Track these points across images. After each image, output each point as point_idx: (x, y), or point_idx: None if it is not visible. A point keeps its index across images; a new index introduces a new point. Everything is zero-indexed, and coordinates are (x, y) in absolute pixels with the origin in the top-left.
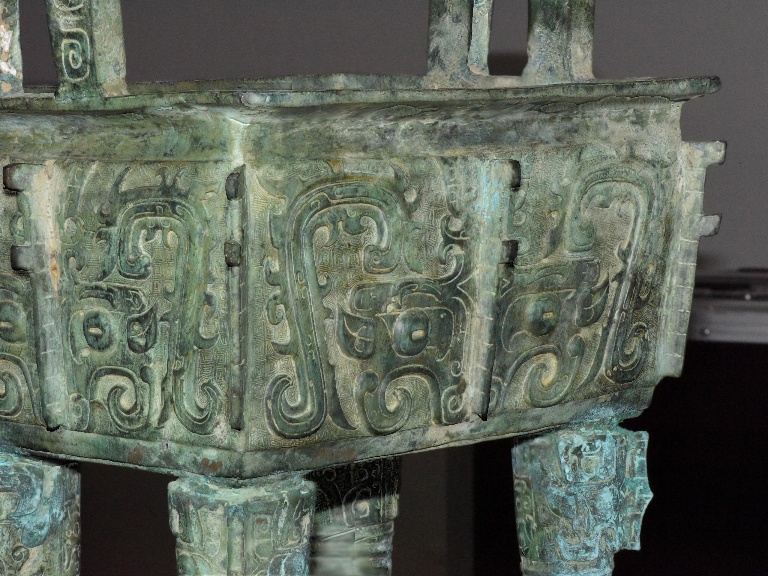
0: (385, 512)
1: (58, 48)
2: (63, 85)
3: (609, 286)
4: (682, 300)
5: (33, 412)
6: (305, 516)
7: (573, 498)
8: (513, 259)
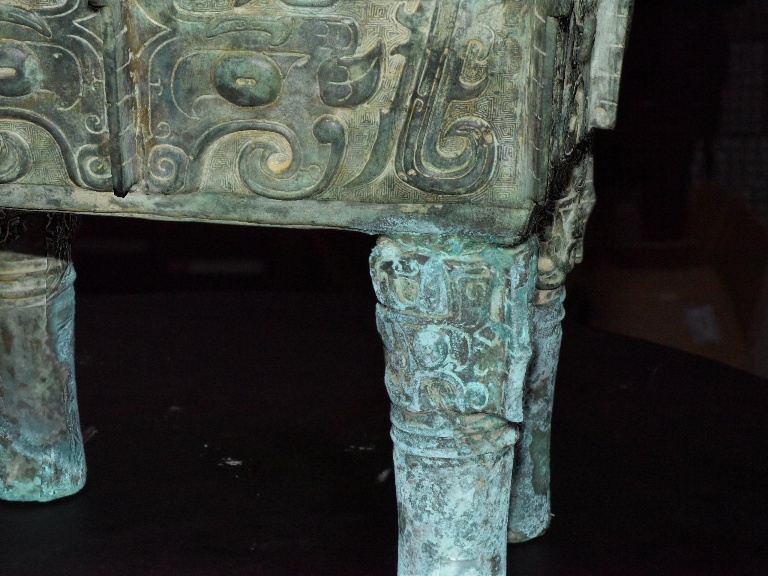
0: None
1: None
2: None
3: (388, 59)
4: (536, 100)
5: None
6: None
7: (389, 326)
8: (95, 2)
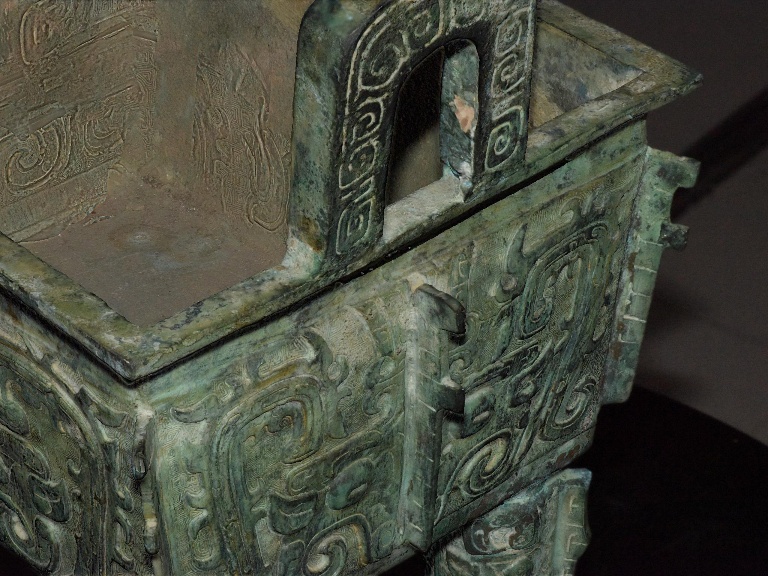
0: None
1: (486, 143)
2: (481, 181)
3: None
4: None
5: (367, 558)
6: None
7: None
8: None
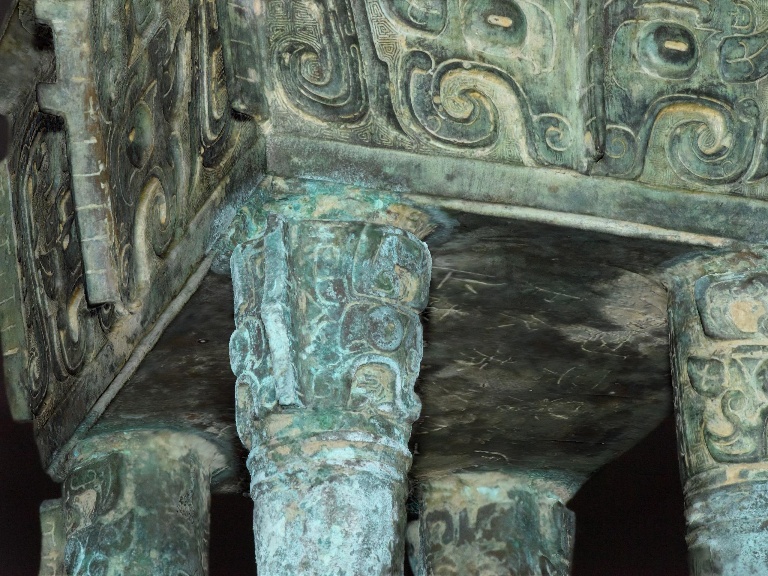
0: (693, 458)
1: None
2: None
3: None
4: None
5: None
6: (93, 495)
7: None
8: (41, 106)
